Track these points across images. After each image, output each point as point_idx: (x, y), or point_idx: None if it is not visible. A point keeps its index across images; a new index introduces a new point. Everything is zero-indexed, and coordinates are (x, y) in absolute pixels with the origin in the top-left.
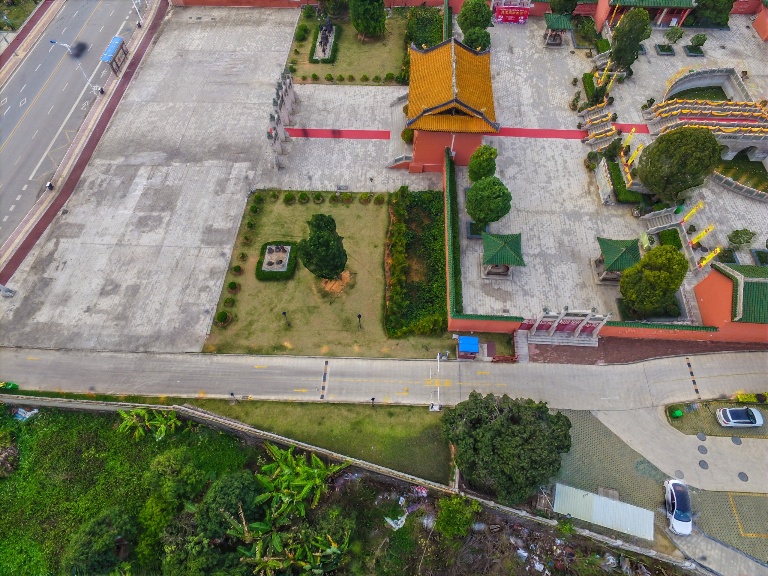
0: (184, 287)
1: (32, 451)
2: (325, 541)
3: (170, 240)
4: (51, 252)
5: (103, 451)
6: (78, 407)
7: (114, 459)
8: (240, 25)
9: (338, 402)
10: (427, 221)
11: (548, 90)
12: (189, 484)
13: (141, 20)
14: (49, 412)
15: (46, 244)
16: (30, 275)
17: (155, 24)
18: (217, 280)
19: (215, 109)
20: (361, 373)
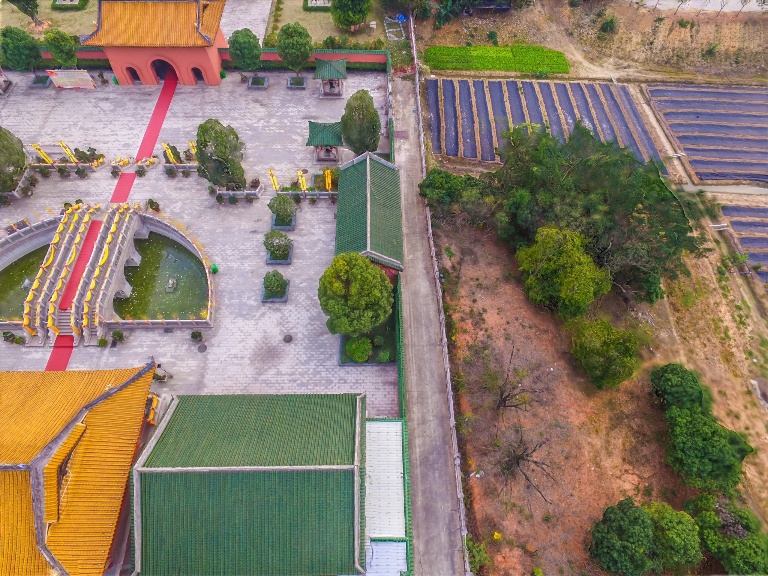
0: None
1: None
2: None
3: None
4: None
5: None
6: None
7: None
8: None
9: None
10: None
11: None
12: None
13: None
14: None
15: None
16: None
17: None
18: None
19: None
20: None
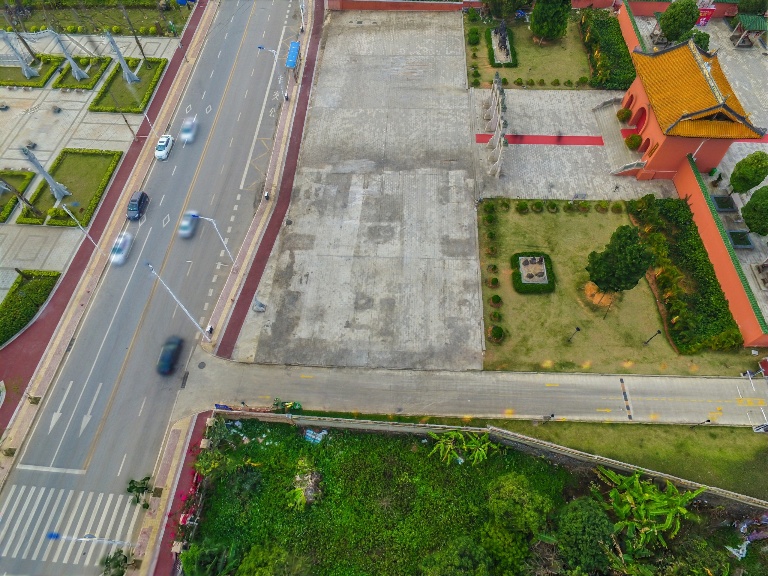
0: (441, 301)
1: (335, 475)
2: (704, 575)
3: (409, 251)
4: (289, 264)
5: (411, 475)
6: (374, 428)
7: (423, 484)
8: (405, 29)
9: (651, 423)
10: (674, 230)
11: (755, 93)
12: (544, 513)
13: (303, 25)
14: (341, 434)
15: (281, 256)
16: (275, 289)
17: (317, 29)
18: (474, 293)
19: (409, 115)
20: (663, 392)
